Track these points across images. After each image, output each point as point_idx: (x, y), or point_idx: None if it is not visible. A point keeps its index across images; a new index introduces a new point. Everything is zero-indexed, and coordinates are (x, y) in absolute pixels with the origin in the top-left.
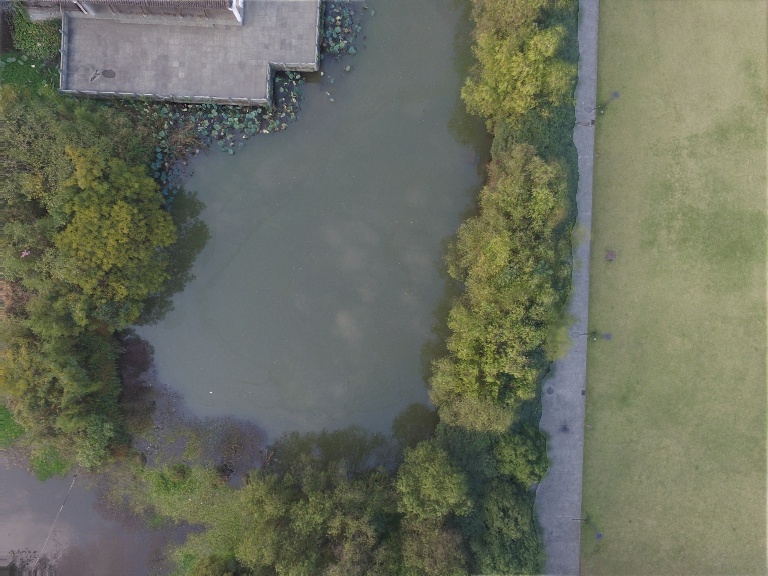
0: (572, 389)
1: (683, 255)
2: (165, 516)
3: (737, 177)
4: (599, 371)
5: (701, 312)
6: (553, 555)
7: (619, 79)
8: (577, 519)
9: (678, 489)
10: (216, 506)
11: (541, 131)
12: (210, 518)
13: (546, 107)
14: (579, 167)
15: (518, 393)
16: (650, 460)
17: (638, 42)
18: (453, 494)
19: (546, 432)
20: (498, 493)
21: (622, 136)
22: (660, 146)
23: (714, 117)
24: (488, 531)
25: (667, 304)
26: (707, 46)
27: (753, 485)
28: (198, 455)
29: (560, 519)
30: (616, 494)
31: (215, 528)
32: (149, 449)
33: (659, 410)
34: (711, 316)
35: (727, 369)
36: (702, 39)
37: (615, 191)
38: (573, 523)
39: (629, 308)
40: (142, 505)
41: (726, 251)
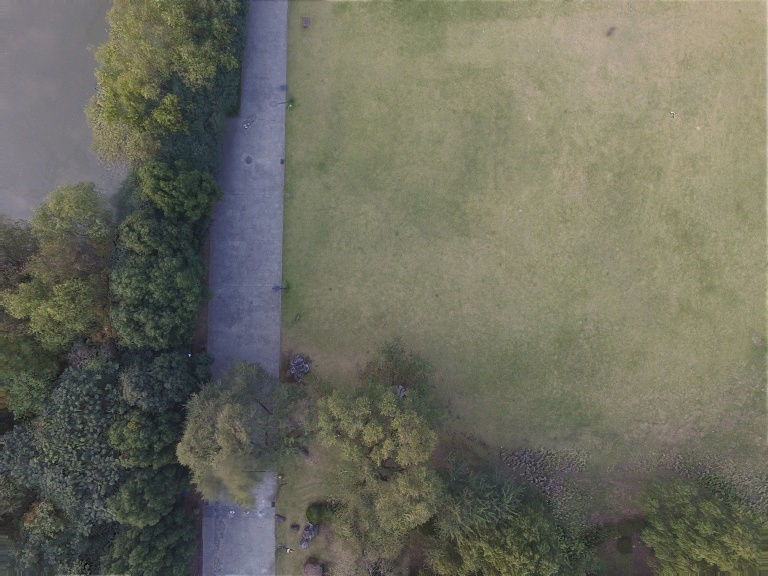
0: (271, 158)
1: (374, 17)
2: None
3: None
4: (297, 139)
5: (396, 75)
6: (253, 324)
7: None
8: None
9: (378, 255)
10: None
11: None
12: None
13: None
14: None
15: (153, 116)
16: (349, 226)
17: None
18: (77, 209)
19: (245, 201)
20: (134, 216)
21: None
22: None
23: None
24: (115, 247)
25: (361, 68)
26: None
27: (455, 250)
28: None
29: (260, 288)
30: (316, 262)
31: None
32: None
33: (357, 176)
34: (406, 79)
35: (424, 132)
36: None
37: None
38: (273, 292)
39: (325, 74)
40: None
41: (418, 12)
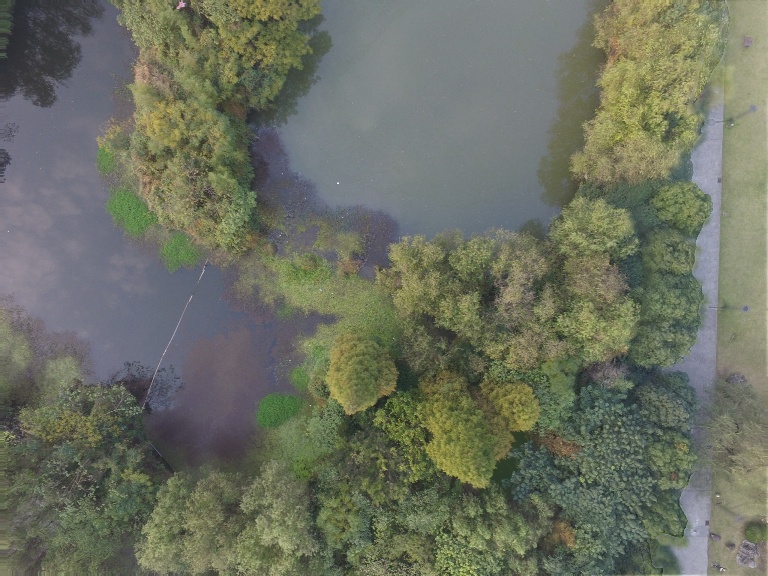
0: (708, 176)
1: None
2: (295, 306)
3: None
4: (735, 158)
5: None
6: None
7: None
8: (714, 307)
9: None
10: (347, 297)
11: None
12: (341, 309)
13: None
14: None
15: (682, 135)
16: None
17: None
18: (623, 227)
19: None
20: (663, 235)
21: None
22: None
23: None
24: (657, 267)
25: None
26: None
27: None
28: (329, 244)
29: None
30: (753, 281)
31: (346, 319)
32: (280, 237)
33: None
34: None
35: None
36: None
37: None
38: (710, 311)
39: (766, 94)
40: (272, 295)
41: None
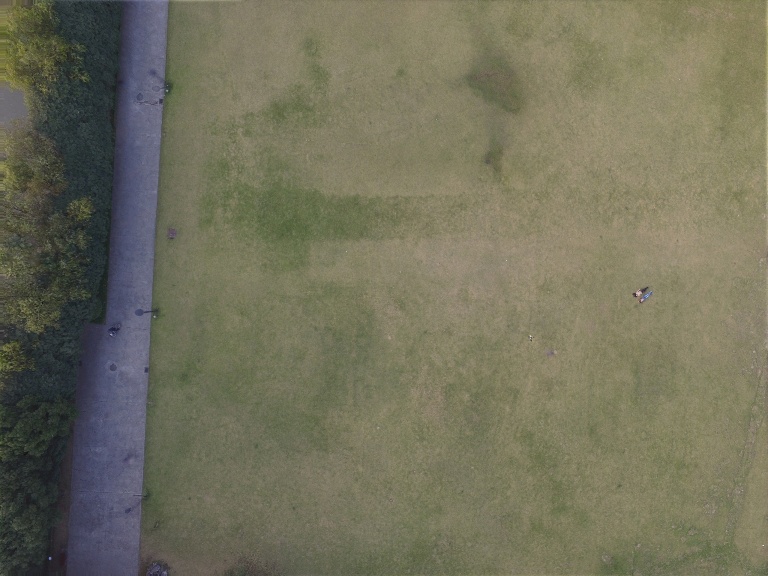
0: (135, 366)
1: (239, 233)
2: None
3: (293, 156)
4: (161, 349)
5: (259, 291)
6: (113, 530)
7: (184, 58)
8: (138, 495)
9: (237, 467)
10: None
11: (41, 106)
12: None
13: (42, 82)
14: (146, 146)
15: None
16: (209, 438)
17: (200, 21)
18: None
19: (108, 408)
20: None
21: (185, 115)
22: (218, 125)
23: (269, 96)
24: None
25: (225, 282)
26: (269, 25)
27: (313, 464)
28: None
29: (121, 495)
30: (176, 471)
31: None
32: None
33: (219, 388)
34: (269, 295)
35: (286, 348)
36: (264, 18)
37: (177, 170)
38: (134, 499)
39: (190, 286)
40: None
41: (282, 230)
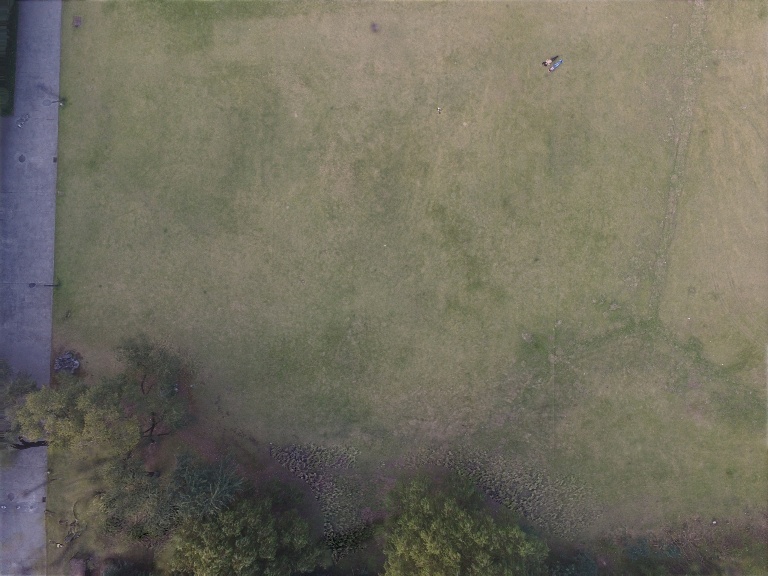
0: (44, 156)
1: (141, 15)
2: None
3: None
4: (69, 137)
5: (163, 73)
6: (25, 321)
7: None
8: (49, 285)
9: (147, 252)
10: None
11: None
12: None
13: None
14: None
15: None
16: (118, 223)
17: None
18: None
19: (18, 199)
20: None
21: None
22: None
23: None
24: None
25: (130, 66)
26: None
27: (223, 247)
28: None
29: None
30: (86, 259)
31: None
32: None
33: (126, 173)
34: (174, 77)
35: (192, 129)
36: None
37: None
38: (45, 289)
39: (95, 73)
40: None
41: (184, 10)
